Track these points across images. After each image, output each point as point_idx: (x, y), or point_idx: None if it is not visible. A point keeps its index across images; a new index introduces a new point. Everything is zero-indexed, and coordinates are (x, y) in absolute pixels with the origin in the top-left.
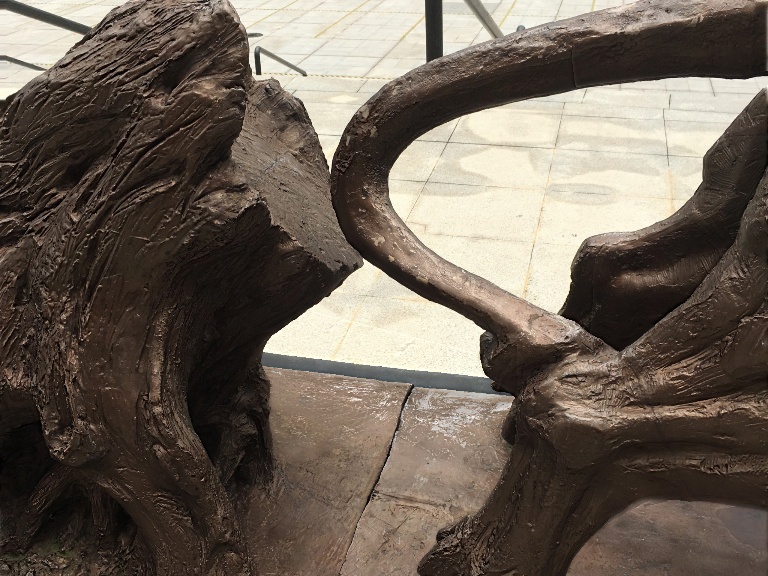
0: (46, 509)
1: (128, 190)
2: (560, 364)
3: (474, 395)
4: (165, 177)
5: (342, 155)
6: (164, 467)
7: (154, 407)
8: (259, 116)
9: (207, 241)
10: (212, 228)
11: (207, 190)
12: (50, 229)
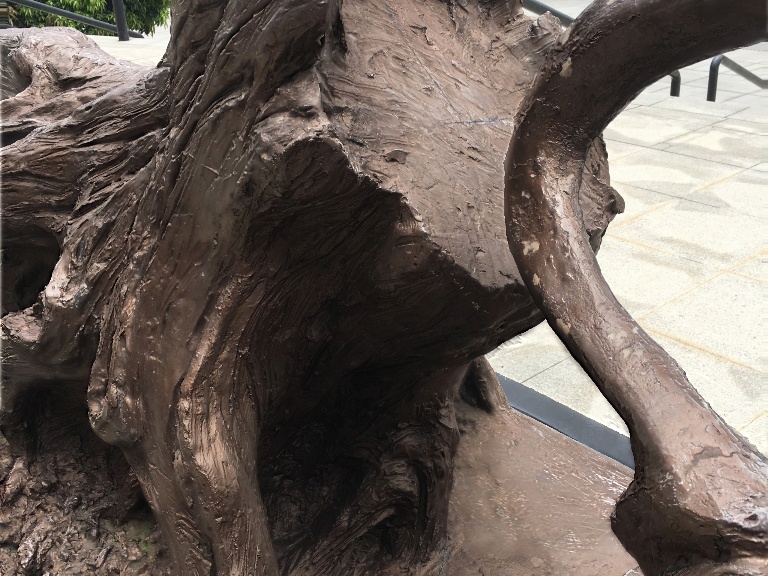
0: None
1: (211, 102)
2: (718, 567)
3: None
4: (240, 87)
5: (524, 104)
6: (177, 482)
7: (181, 399)
8: (505, 60)
9: (262, 185)
10: (262, 165)
11: (271, 110)
12: None
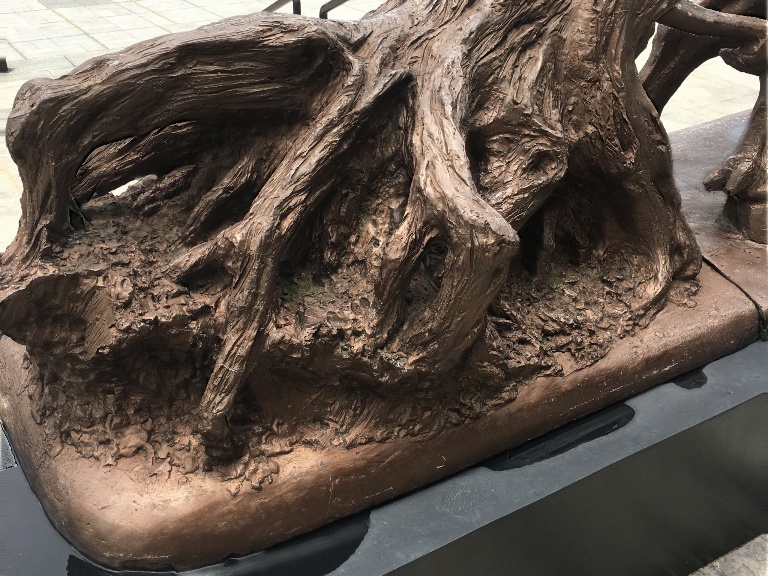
0: (555, 246)
1: None
2: None
3: None
4: None
5: None
6: None
7: (659, 120)
8: None
9: None
10: None
11: None
12: (567, 26)
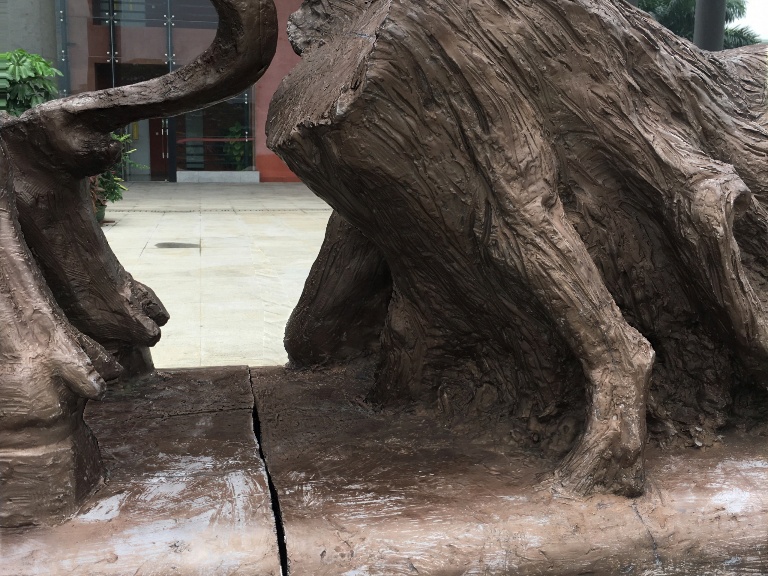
0: None
1: None
2: None
3: (163, 530)
4: None
5: None
6: None
7: None
8: None
9: None
10: None
11: None
12: None
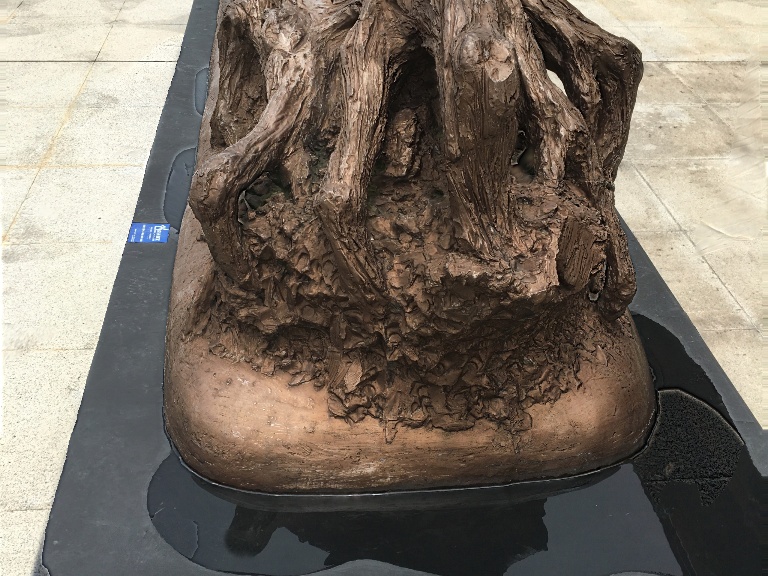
0: None
1: None
2: None
3: None
4: None
5: None
6: None
7: None
8: None
9: None
10: None
11: None
12: None
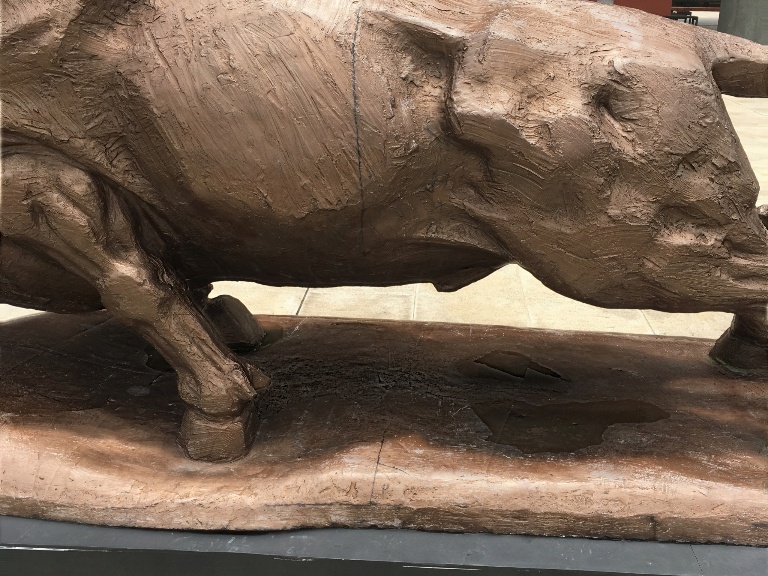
0: None
1: None
2: None
3: None
4: None
5: None
6: None
7: None
8: None
9: None
10: None
11: None
12: None
